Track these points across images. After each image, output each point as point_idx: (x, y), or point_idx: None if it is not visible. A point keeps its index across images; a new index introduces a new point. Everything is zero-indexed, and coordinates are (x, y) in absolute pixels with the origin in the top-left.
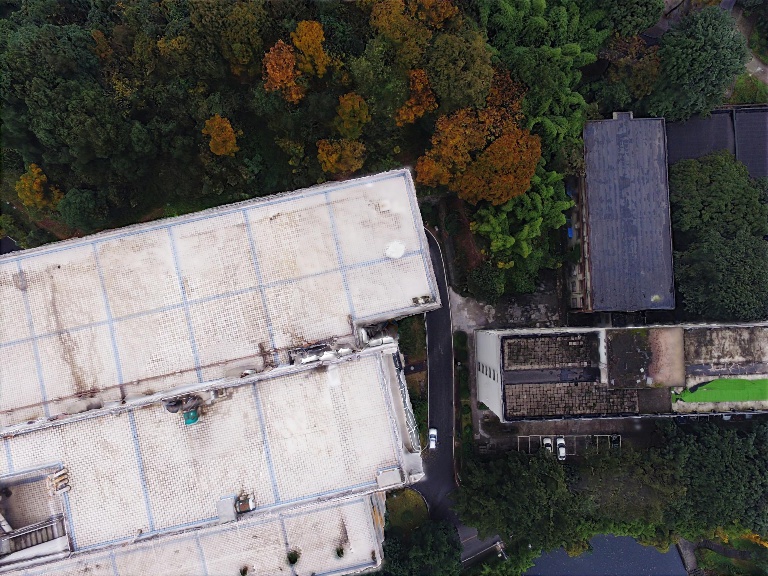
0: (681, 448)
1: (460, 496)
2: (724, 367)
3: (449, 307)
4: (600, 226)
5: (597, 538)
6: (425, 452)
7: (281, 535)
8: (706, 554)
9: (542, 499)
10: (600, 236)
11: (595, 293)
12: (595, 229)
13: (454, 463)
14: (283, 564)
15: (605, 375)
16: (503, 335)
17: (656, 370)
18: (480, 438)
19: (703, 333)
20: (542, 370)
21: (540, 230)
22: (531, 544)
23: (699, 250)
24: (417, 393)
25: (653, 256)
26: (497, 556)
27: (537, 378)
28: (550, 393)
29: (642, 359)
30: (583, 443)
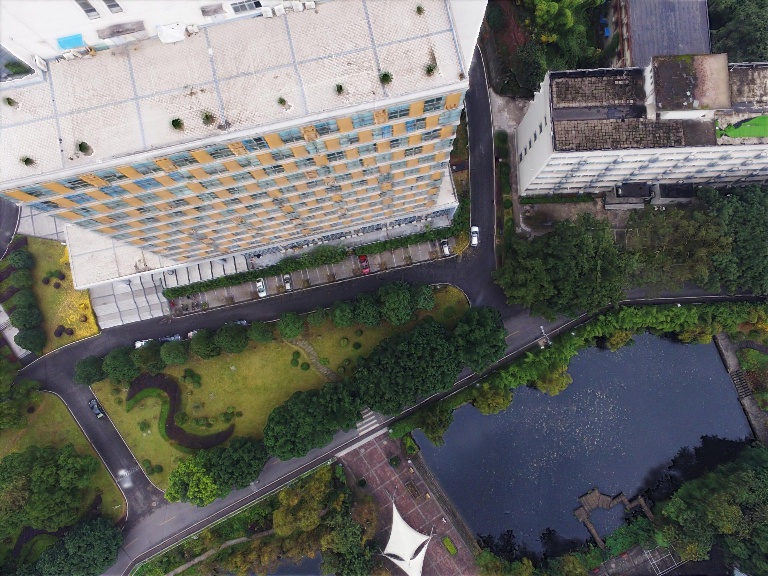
0: (724, 205)
1: (505, 268)
2: (767, 105)
3: (490, 107)
4: (638, 3)
5: (638, 340)
6: (467, 251)
7: (374, 62)
8: (748, 353)
9: (590, 247)
10: (639, 12)
11: (635, 65)
12: (634, 6)
13: (495, 261)
14: (376, 88)
15: (651, 111)
16: (552, 72)
17: (702, 94)
18: (521, 231)
19: (745, 73)
20: (589, 108)
21: (579, 19)
22: (574, 334)
23: (736, 19)
24: (459, 192)
25: (690, 30)
26: (540, 348)
27: (585, 116)
28: (598, 129)
29: (688, 83)
30: (623, 236)
